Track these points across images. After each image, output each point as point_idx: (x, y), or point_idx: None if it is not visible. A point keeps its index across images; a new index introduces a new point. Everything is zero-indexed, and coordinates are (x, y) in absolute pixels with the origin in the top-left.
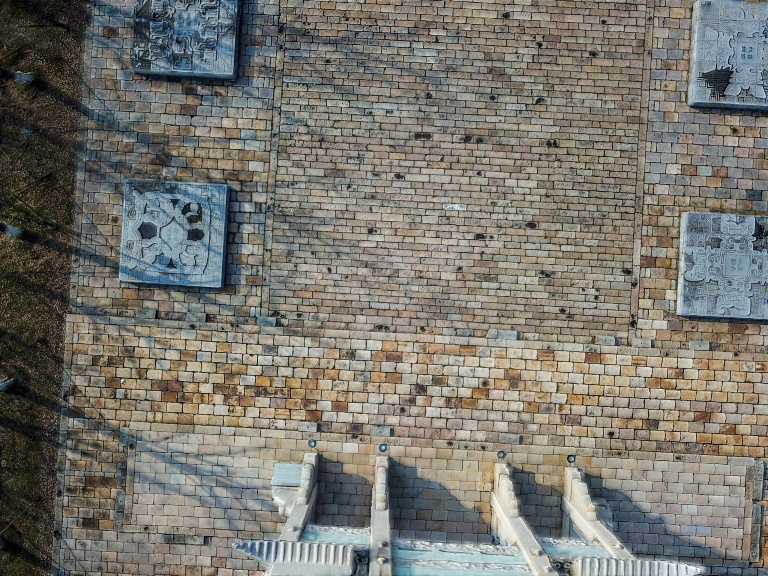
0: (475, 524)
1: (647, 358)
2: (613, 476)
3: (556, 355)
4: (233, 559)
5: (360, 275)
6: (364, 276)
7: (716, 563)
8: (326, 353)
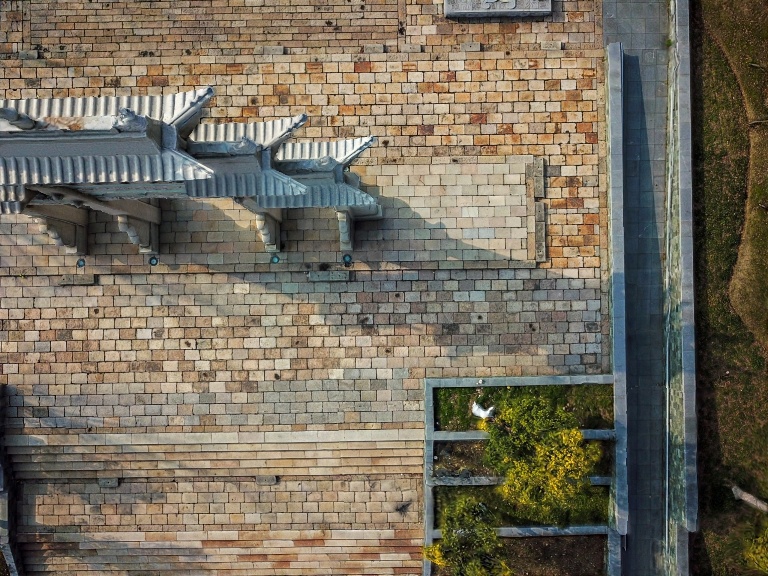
0: (252, 243)
1: (417, 63)
2: (390, 183)
3: (324, 67)
4: (8, 298)
5: (121, 2)
6: (125, 3)
7: (502, 265)
8: (91, 82)
